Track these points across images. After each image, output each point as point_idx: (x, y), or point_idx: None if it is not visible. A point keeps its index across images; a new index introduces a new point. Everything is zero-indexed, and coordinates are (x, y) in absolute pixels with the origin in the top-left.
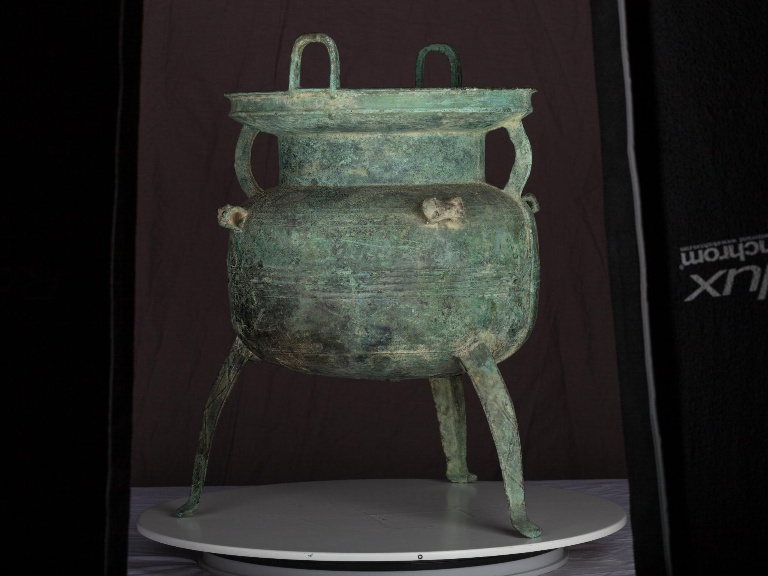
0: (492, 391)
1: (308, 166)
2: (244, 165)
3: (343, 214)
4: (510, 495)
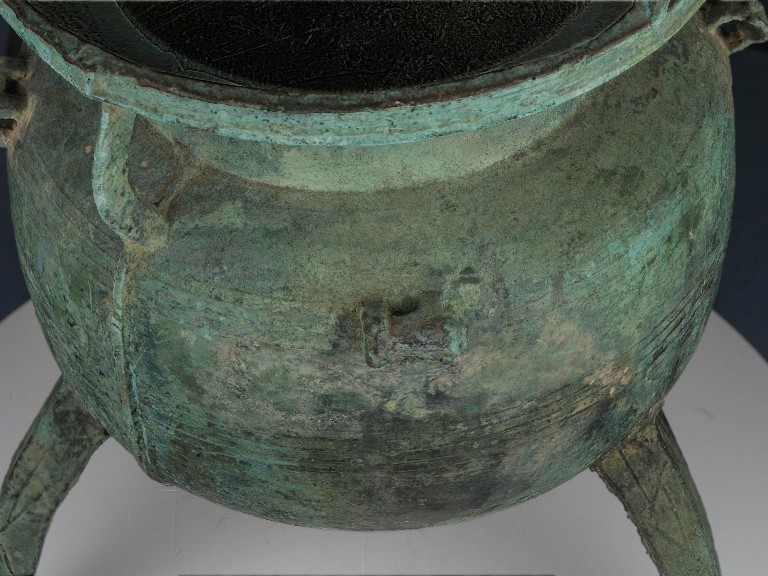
0: None
1: None
2: None
3: None
4: None
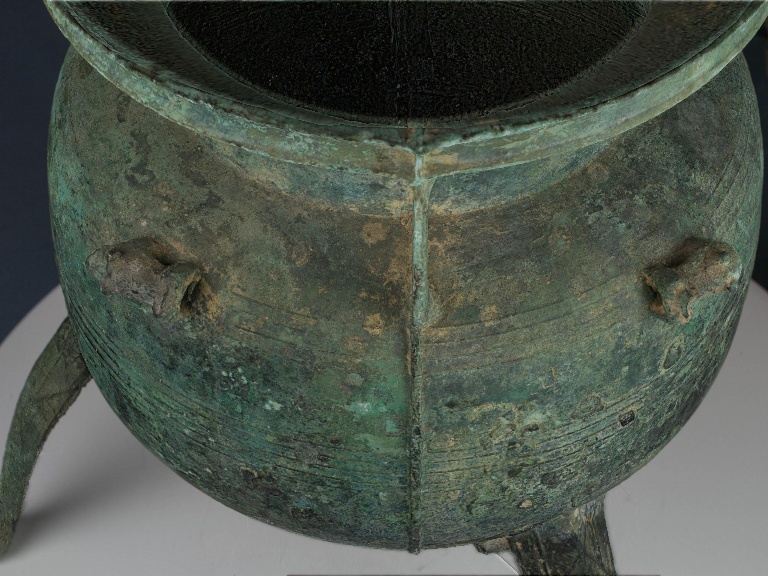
0: None
1: None
2: None
3: None
4: None
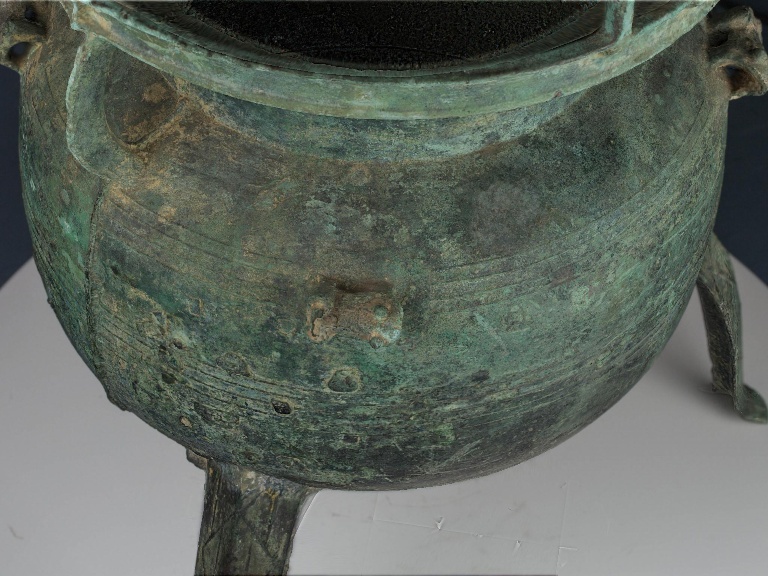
0: (712, 259)
1: (475, 116)
2: (97, 124)
3: (657, 195)
4: (736, 382)
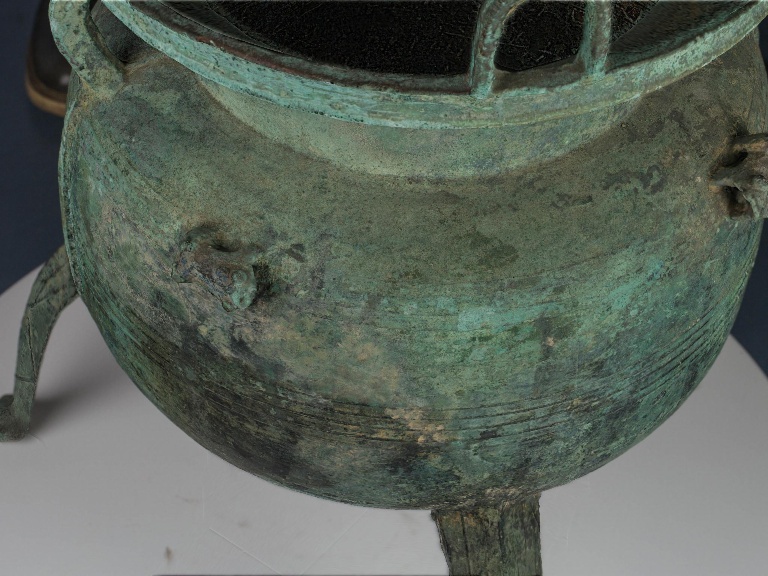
0: None
1: None
2: None
3: None
4: None
